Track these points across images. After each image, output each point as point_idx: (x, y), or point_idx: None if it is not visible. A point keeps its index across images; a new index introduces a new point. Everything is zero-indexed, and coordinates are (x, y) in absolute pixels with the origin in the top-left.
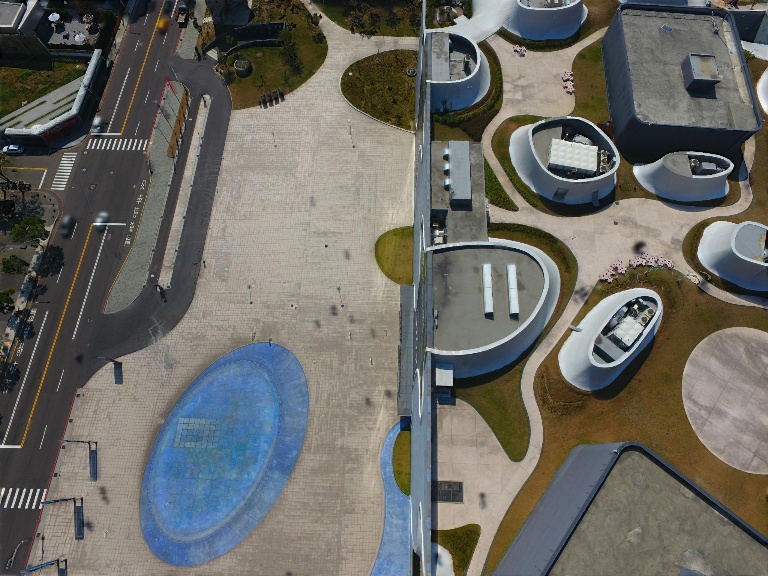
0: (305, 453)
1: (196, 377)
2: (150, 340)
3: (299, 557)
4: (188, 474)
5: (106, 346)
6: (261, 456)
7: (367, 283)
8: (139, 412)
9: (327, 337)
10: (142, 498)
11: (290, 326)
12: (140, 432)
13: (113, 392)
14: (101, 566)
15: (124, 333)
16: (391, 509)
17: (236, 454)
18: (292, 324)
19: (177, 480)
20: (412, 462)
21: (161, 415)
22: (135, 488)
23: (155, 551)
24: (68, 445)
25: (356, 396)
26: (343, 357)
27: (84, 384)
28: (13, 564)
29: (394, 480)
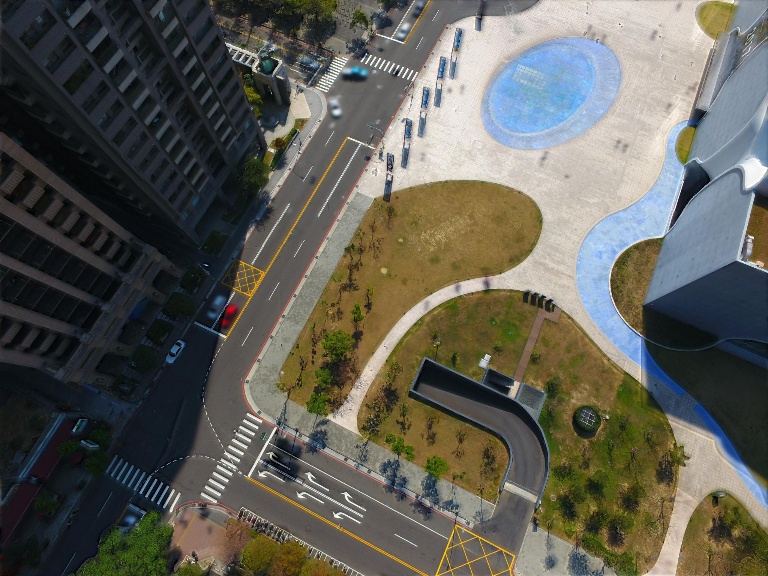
0: (610, 114)
1: (536, 44)
2: (504, 13)
3: (592, 169)
4: (519, 98)
5: (471, 6)
6: (574, 106)
7: (684, 29)
8: (490, 51)
9: (643, 52)
10: (484, 99)
11: (615, 36)
12: (489, 62)
13: (473, 34)
14: (449, 126)
15: (486, 2)
16: (667, 167)
17: (556, 98)
18: (617, 35)
19: (510, 98)
20: (708, 129)
21: (506, 58)
22: (480, 92)
23: (488, 131)
24: (436, 53)
25: (657, 94)
26: (653, 68)
27: (452, 23)
28: (390, 104)
29: (674, 152)
